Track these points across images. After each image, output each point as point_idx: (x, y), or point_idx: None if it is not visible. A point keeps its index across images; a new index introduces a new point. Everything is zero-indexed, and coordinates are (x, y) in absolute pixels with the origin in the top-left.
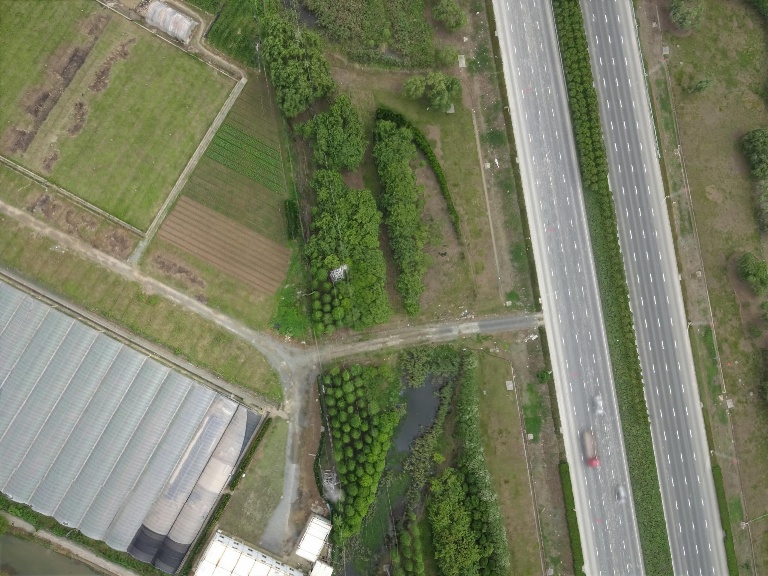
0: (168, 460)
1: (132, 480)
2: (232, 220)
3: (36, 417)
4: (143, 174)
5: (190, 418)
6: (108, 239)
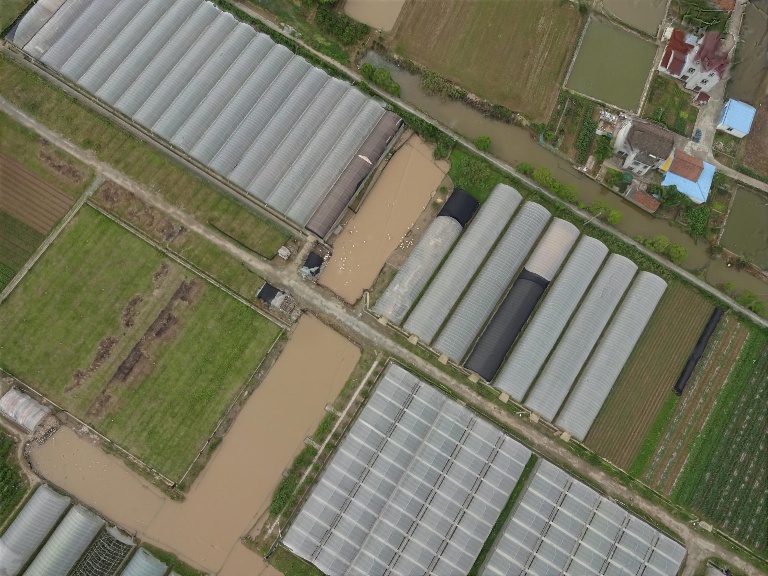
0: (88, 13)
1: (121, 4)
2: (2, 210)
3: (188, 58)
4: (79, 256)
5: (63, 42)
6: (120, 200)
